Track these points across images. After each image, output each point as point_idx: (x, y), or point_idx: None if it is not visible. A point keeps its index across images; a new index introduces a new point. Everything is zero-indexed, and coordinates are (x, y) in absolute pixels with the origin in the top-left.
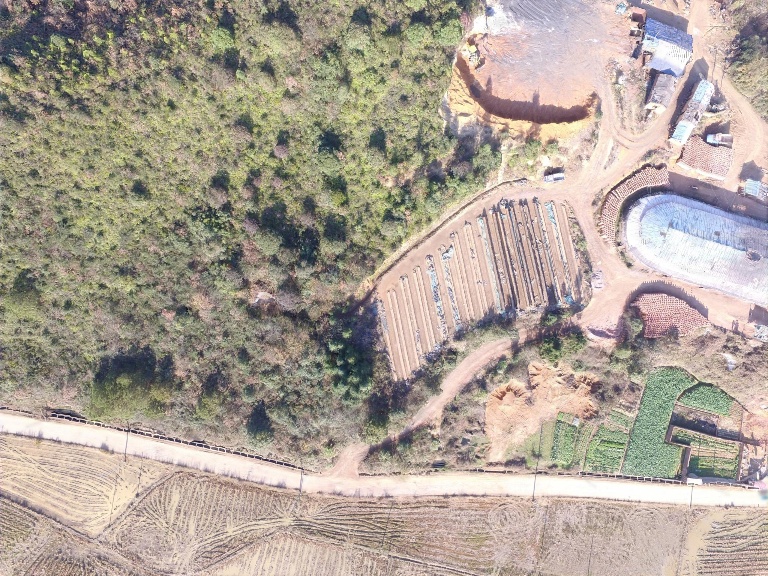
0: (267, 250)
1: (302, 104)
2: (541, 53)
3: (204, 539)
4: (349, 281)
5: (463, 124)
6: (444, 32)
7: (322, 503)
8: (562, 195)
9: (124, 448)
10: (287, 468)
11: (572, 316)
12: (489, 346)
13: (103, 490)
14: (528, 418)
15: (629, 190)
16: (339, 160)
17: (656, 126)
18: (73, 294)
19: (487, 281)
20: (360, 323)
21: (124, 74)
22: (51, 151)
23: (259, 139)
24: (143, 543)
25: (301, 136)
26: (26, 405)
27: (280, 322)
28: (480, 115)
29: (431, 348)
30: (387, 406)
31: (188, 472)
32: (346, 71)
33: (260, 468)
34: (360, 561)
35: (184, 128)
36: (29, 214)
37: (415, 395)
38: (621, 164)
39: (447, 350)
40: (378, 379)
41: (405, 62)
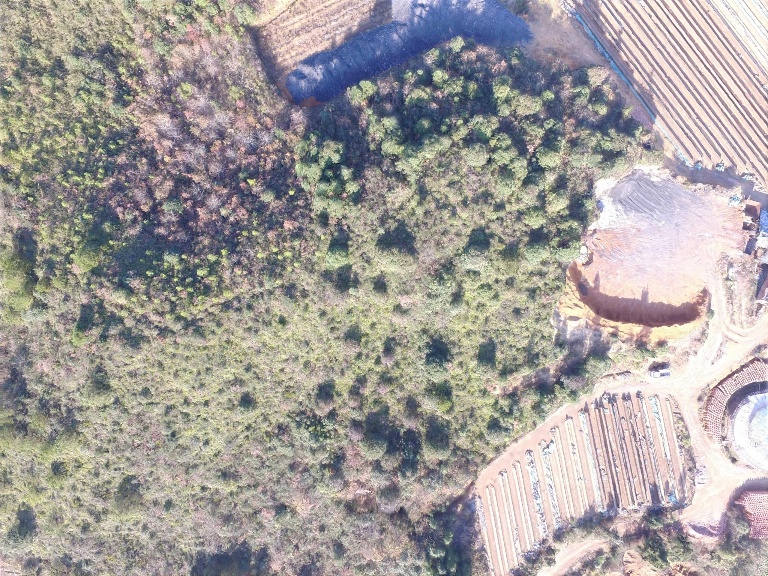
0: (371, 458)
1: (412, 316)
2: (651, 248)
3: None
4: (452, 486)
5: (572, 328)
6: (564, 253)
7: None
8: (667, 389)
9: None
10: None
11: (673, 511)
12: None
13: None
14: None
15: (737, 385)
16: (448, 370)
17: (766, 320)
18: (174, 495)
19: (588, 478)
20: (459, 521)
21: (237, 292)
22: (164, 372)
23: (367, 348)
24: None
25: (407, 341)
26: None
27: (378, 519)
28: (589, 318)
29: (530, 546)
30: None
31: None
32: (460, 287)
33: None
34: None
35: (293, 341)
36: (140, 431)
37: None
38: (729, 358)
39: (546, 548)
40: None
41: (520, 277)
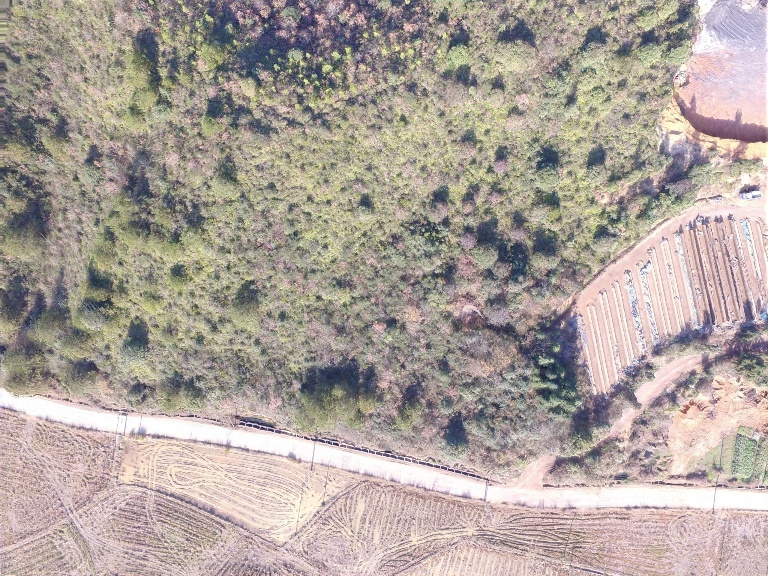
0: (484, 264)
1: (527, 121)
2: (743, 72)
3: (389, 548)
4: (560, 296)
5: (673, 142)
6: (676, 52)
7: (505, 513)
8: (757, 212)
9: (311, 457)
10: (472, 478)
11: None
12: (680, 361)
13: (289, 498)
14: (709, 432)
15: None
16: (559, 176)
17: None
18: (289, 305)
19: (684, 297)
20: (562, 337)
21: (361, 89)
22: (291, 165)
23: (481, 154)
24: (329, 551)
25: (518, 152)
26: (217, 413)
27: (484, 335)
28: (689, 133)
29: (630, 362)
30: (587, 419)
31: (373, 481)
32: (575, 89)
33: (445, 478)
34: (542, 571)
35: (412, 143)
36: (265, 227)
37: (614, 409)
38: None
39: (645, 364)
40: (581, 393)
41: (631, 81)
